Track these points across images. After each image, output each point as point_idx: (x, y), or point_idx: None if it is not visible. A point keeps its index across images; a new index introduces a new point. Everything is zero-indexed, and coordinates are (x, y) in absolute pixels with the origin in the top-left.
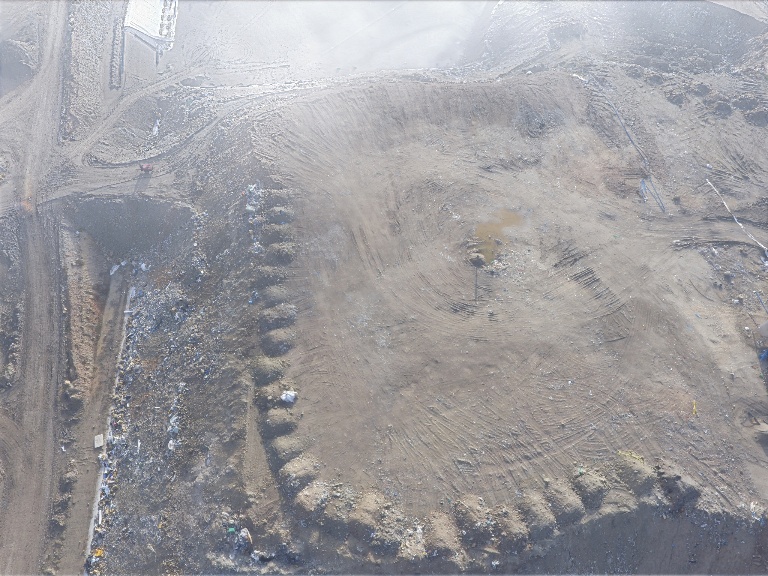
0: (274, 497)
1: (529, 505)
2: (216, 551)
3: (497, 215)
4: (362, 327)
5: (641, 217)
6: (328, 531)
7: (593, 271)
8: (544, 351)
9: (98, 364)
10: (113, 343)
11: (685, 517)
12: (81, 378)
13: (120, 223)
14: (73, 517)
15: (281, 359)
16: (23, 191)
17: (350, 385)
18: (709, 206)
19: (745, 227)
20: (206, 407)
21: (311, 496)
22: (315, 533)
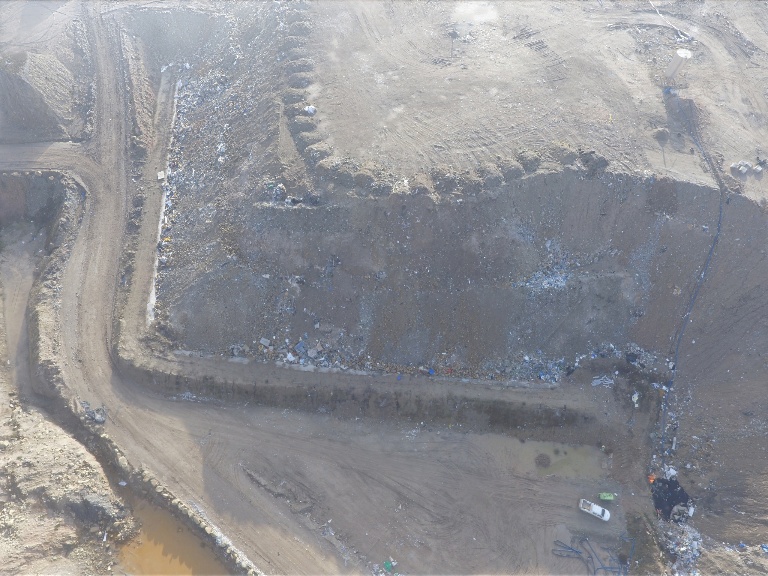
0: (301, 165)
1: (485, 167)
2: (260, 201)
3: (470, 8)
4: (364, 72)
5: (584, 10)
6: (340, 183)
7: (543, 41)
8: (502, 86)
9: (156, 129)
10: (167, 116)
11: (597, 179)
12: (144, 135)
13: (168, 31)
14: (145, 220)
15: (304, 90)
16: (89, 4)
17: (356, 104)
18: (638, 3)
19: (665, 17)
20: (247, 130)
21: (328, 161)
22: (331, 184)
